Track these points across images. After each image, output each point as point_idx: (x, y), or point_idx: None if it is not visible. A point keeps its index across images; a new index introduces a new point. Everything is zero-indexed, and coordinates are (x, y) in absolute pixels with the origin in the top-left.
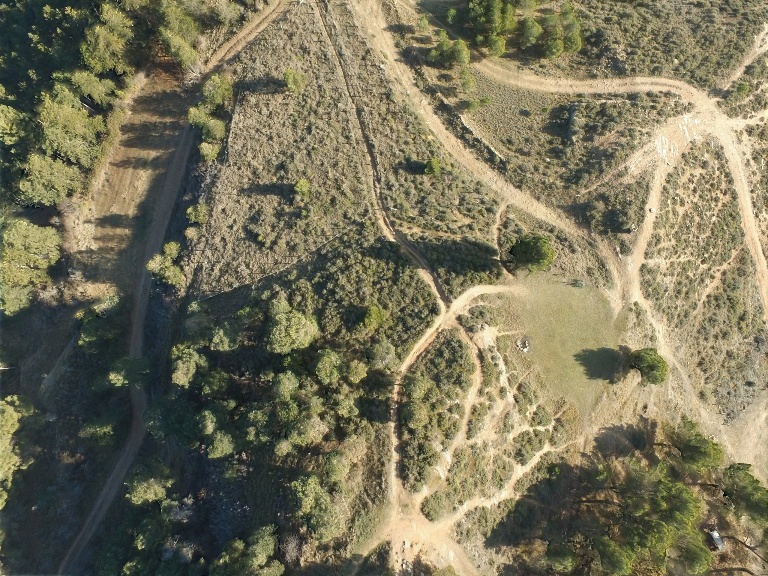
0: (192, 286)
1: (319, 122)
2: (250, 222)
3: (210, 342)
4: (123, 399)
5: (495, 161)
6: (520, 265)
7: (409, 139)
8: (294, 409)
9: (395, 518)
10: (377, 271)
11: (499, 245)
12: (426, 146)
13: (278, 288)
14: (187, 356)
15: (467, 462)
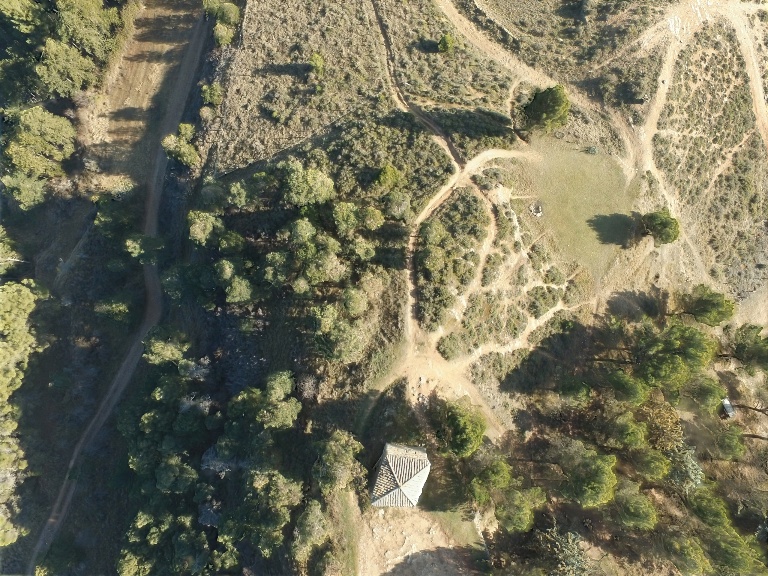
0: (207, 166)
1: (333, 5)
2: (265, 101)
3: (226, 211)
4: (137, 285)
5: (508, 41)
6: (535, 122)
7: (422, 20)
8: (312, 247)
9: (411, 355)
10: (392, 137)
11: (512, 116)
12: (439, 27)
13: (293, 158)
14: (204, 216)
15: (482, 308)
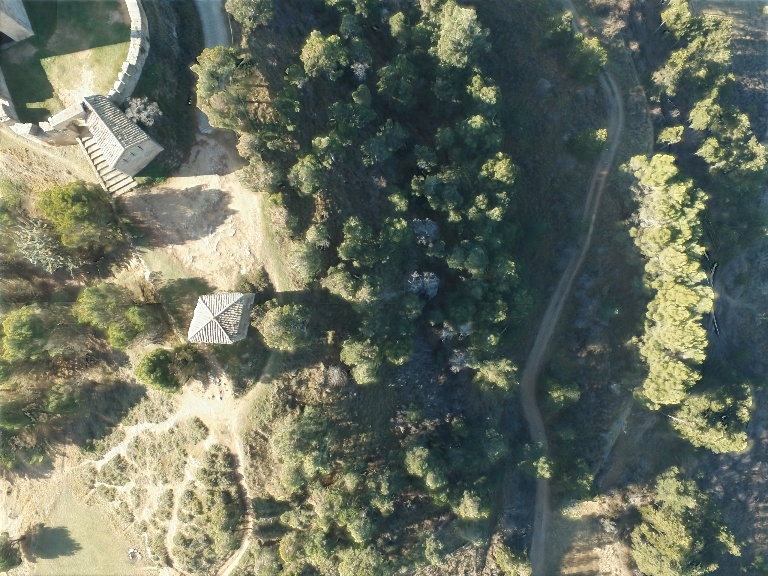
0: (486, 548)
1: None
2: None
3: (455, 515)
4: (547, 411)
5: None
6: None
7: None
8: (343, 521)
9: (233, 420)
10: None
11: None
12: None
13: None
14: None
15: (170, 467)
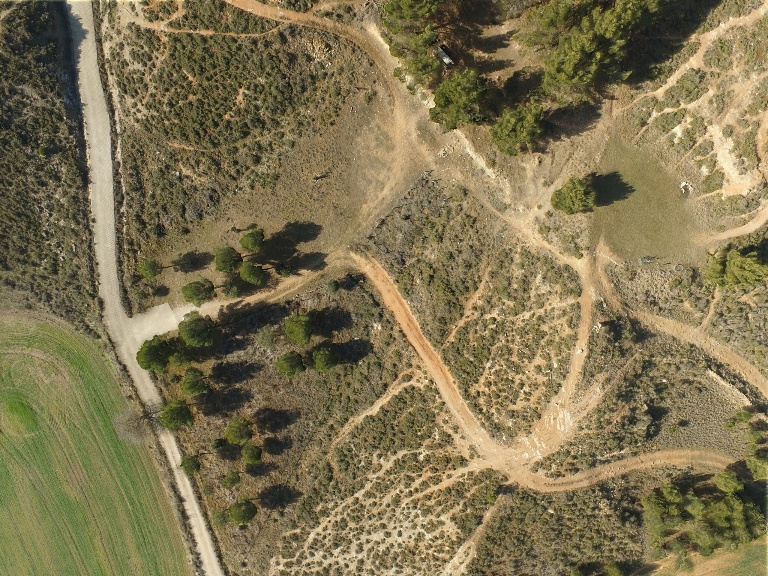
0: None
1: None
2: None
3: None
4: None
5: (716, 366)
6: None
7: None
8: None
9: None
10: None
11: None
12: None
13: None
14: None
15: (767, 54)
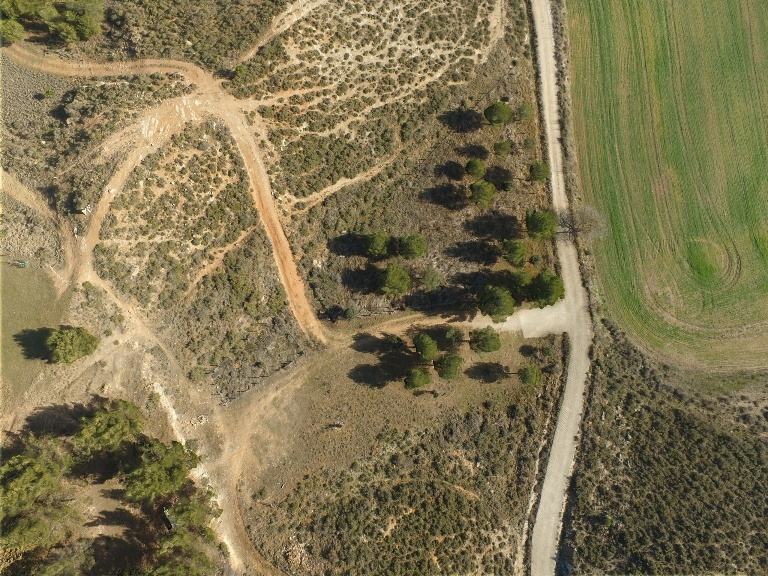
0: None
1: None
2: None
3: None
4: None
5: None
6: None
7: None
8: None
9: None
10: None
11: None
12: None
13: None
14: None
15: None
